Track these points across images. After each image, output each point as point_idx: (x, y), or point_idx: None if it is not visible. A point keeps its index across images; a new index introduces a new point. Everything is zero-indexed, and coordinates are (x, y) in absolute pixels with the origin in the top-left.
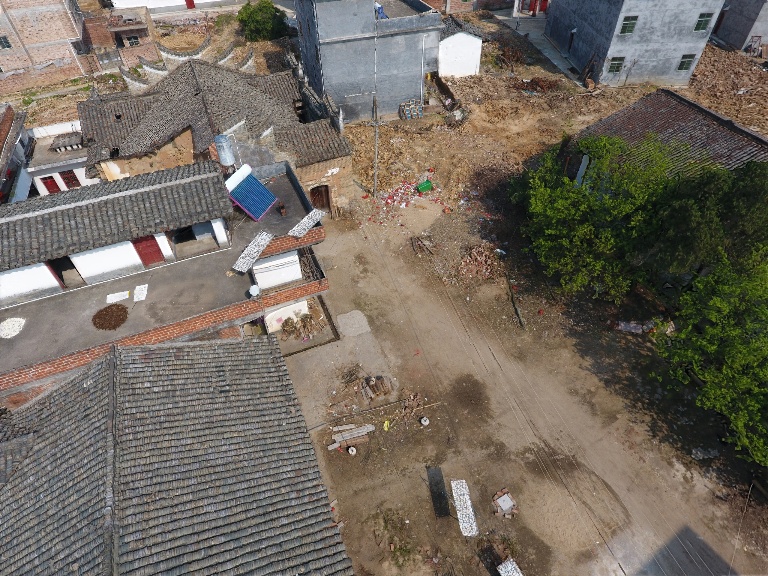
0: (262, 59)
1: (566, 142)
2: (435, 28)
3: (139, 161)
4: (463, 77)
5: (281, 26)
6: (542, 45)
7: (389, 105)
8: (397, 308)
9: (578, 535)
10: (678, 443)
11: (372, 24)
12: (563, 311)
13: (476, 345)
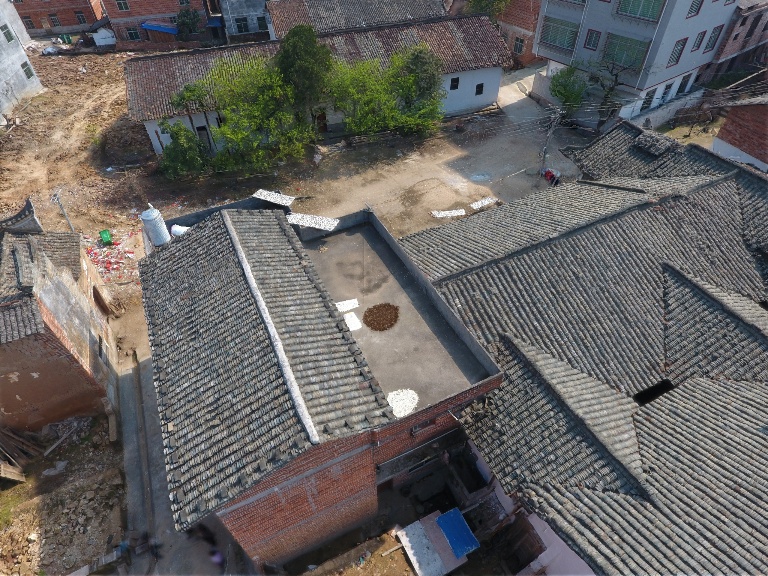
0: None
1: (105, 142)
2: None
3: None
4: None
5: None
6: None
7: None
8: None
9: (448, 192)
10: (394, 159)
11: None
12: (299, 180)
13: None
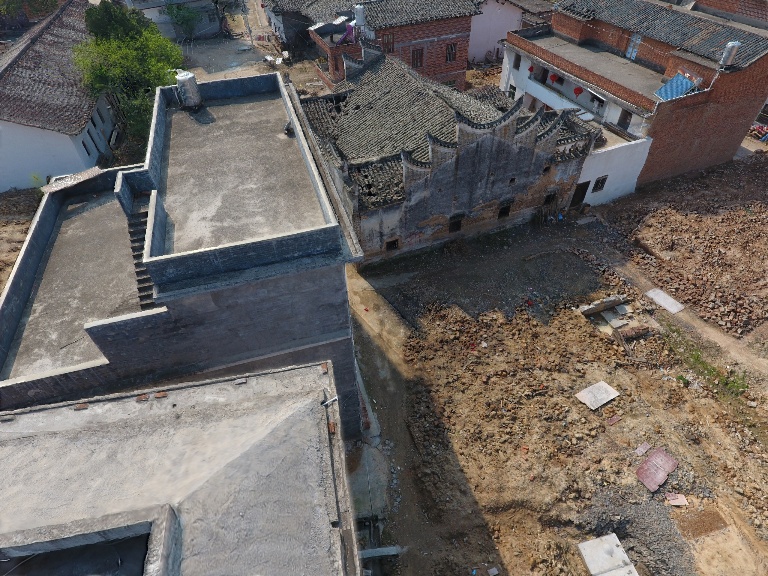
0: None
1: None
2: None
3: None
4: None
5: None
6: None
7: None
8: None
9: None
10: None
11: None
12: None
13: None
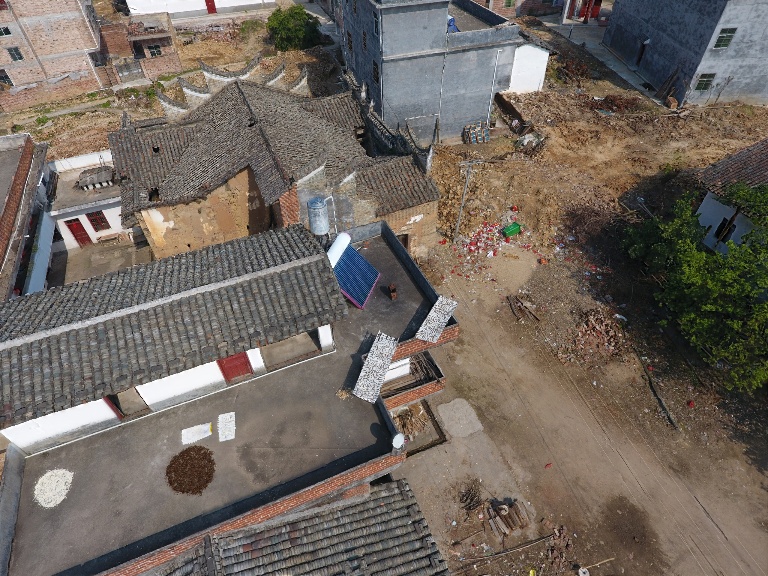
0: (298, 71)
1: (671, 176)
2: (512, 42)
3: (186, 207)
4: (526, 94)
5: (314, 34)
6: (603, 56)
7: (452, 128)
8: (510, 396)
9: None
10: None
11: (443, 38)
12: (719, 403)
13: (621, 452)
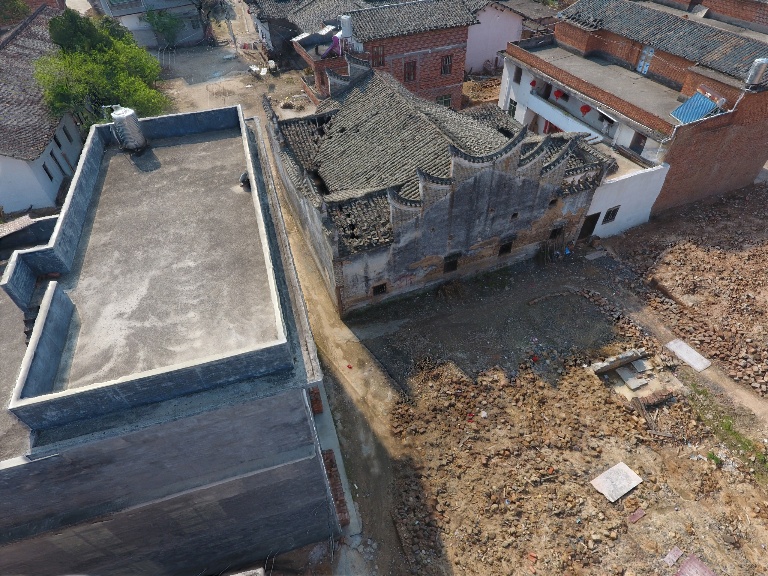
0: None
1: (5, 219)
2: None
3: None
4: None
5: None
6: None
7: None
8: None
9: None
10: None
11: None
12: None
13: None
